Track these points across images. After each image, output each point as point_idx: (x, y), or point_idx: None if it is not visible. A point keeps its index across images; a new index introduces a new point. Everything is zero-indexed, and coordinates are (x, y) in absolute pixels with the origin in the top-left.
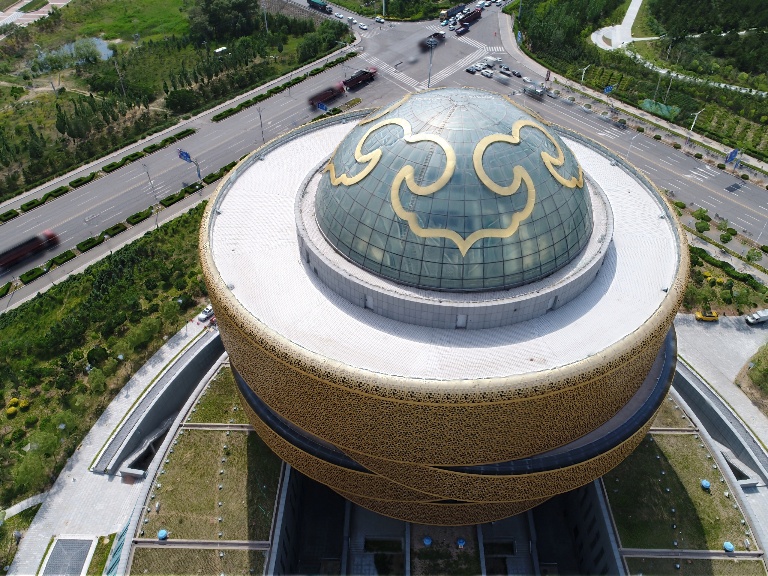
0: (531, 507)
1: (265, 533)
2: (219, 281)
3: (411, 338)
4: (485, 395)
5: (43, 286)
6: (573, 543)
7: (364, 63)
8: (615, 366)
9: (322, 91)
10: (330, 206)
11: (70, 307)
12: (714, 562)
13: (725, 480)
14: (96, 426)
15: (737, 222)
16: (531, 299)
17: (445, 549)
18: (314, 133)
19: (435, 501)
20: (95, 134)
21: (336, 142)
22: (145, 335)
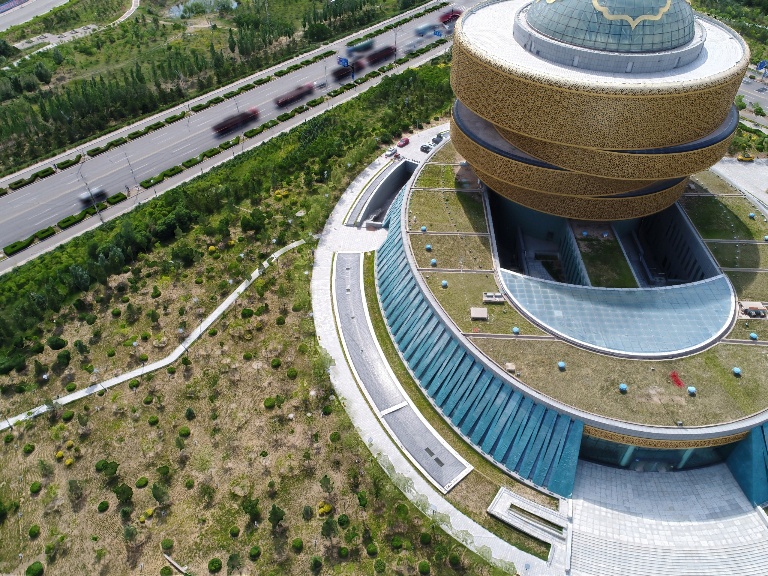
0: (648, 214)
1: (484, 230)
2: (487, 53)
3: (602, 75)
4: (650, 91)
5: (263, 139)
6: (662, 270)
7: (456, 10)
8: (715, 85)
9: (428, 28)
10: (547, 16)
11: (289, 150)
12: (759, 245)
13: (764, 215)
14: (338, 205)
15: (765, 109)
16: (668, 55)
17: (596, 238)
18: (499, 3)
19: (597, 196)
20: (255, 55)
21: (516, 7)
22: (359, 156)
